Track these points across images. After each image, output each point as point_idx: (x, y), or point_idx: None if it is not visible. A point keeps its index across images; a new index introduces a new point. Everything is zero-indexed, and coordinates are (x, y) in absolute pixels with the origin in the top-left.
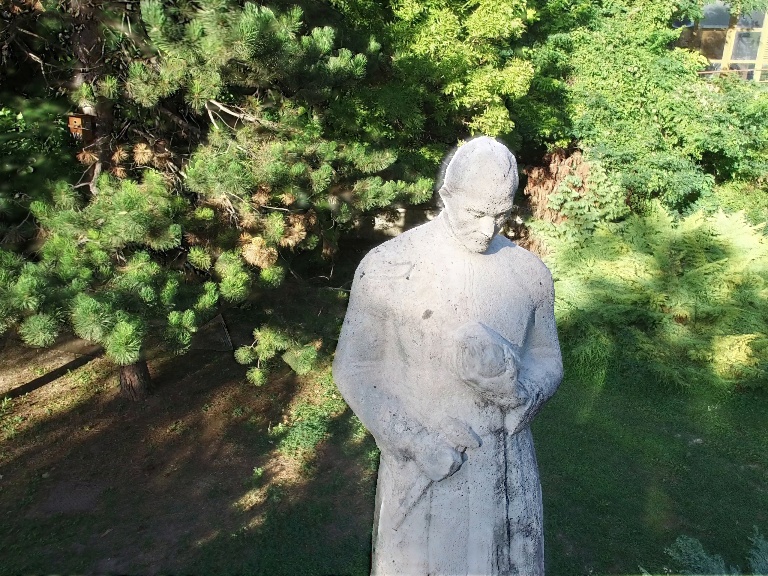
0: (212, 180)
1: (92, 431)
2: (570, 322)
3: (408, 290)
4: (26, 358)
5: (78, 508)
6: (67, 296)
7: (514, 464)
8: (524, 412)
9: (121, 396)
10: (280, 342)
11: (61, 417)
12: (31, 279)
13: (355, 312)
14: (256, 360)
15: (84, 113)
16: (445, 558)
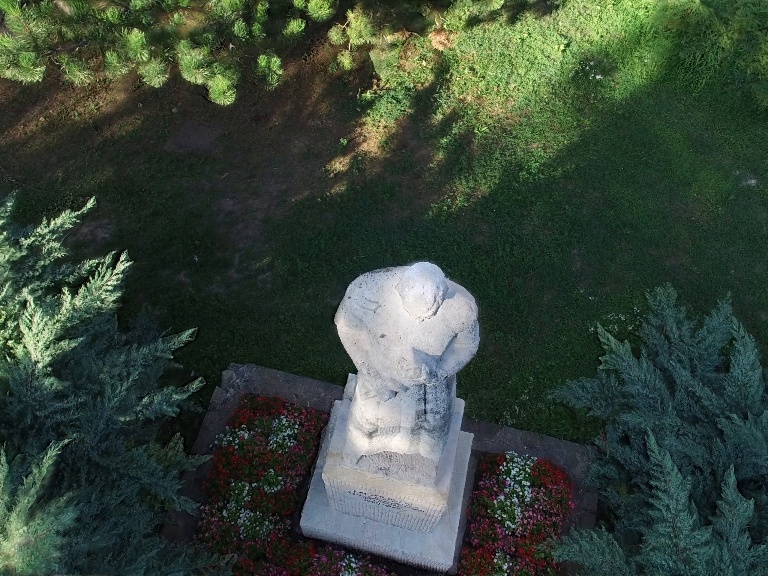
0: None
1: None
2: (692, 18)
3: (374, 319)
4: None
5: (202, 148)
6: (171, 36)
7: (431, 393)
8: (435, 384)
9: None
10: (369, 37)
11: None
12: (140, 37)
13: (345, 309)
14: (347, 42)
15: None
16: (388, 415)
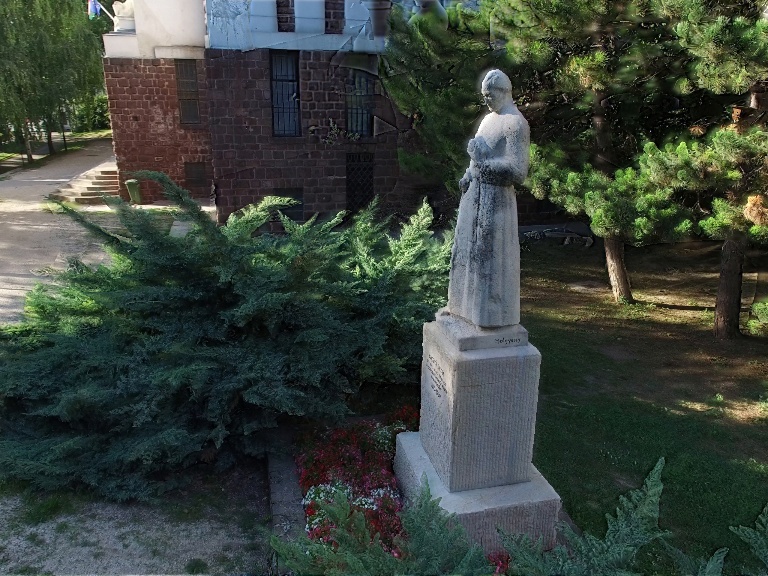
0: (719, 144)
1: (670, 337)
2: None
3: None
4: (695, 295)
5: (612, 357)
6: None
7: None
8: None
9: (711, 331)
10: None
11: (666, 324)
12: (574, 175)
13: None
14: None
15: (750, 106)
16: None
